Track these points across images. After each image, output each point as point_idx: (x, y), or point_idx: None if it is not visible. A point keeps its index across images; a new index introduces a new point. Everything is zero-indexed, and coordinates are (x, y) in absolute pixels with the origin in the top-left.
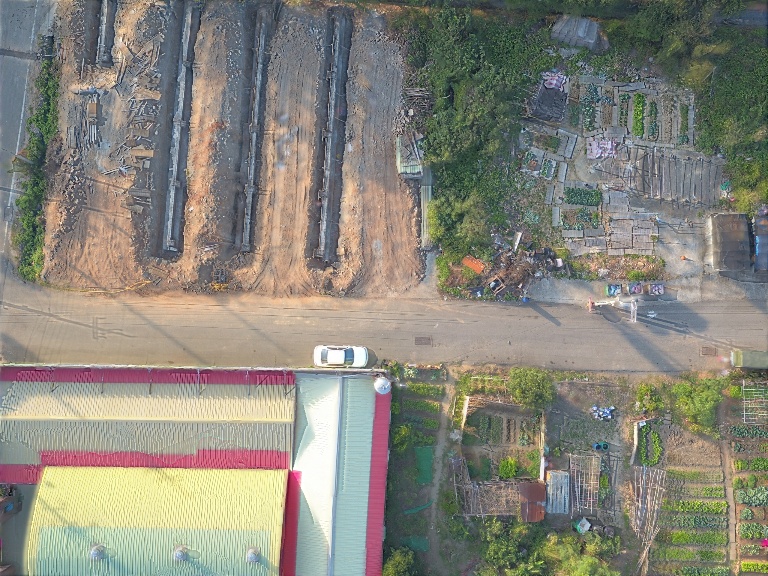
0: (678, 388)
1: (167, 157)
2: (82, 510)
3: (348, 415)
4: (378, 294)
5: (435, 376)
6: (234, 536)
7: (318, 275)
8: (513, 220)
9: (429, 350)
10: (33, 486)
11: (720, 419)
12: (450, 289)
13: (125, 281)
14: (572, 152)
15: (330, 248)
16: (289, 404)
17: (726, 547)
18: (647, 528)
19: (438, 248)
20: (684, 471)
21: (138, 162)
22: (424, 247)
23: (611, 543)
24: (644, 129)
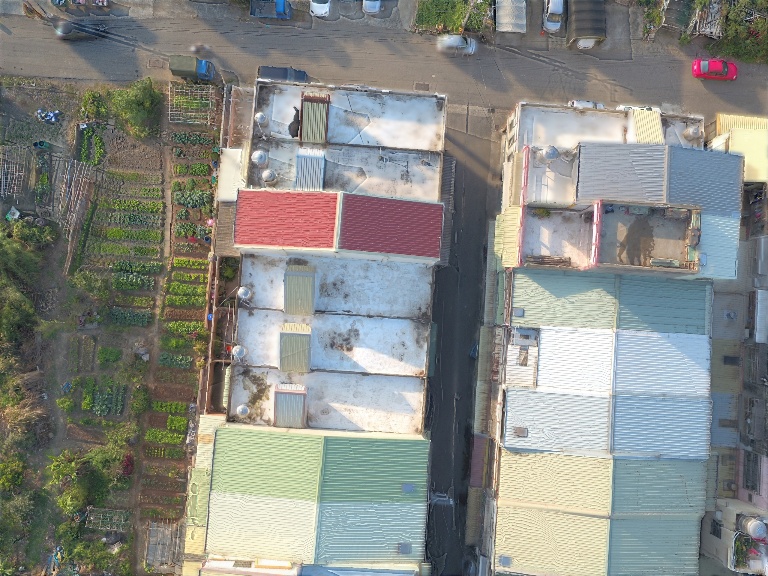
0: (115, 92)
1: None
2: None
3: None
4: None
5: None
6: None
7: None
8: None
9: None
10: None
11: (163, 126)
12: None
13: None
14: None
15: None
16: None
17: (161, 244)
18: (69, 215)
19: None
20: (123, 172)
21: None
22: None
23: (35, 229)
24: None
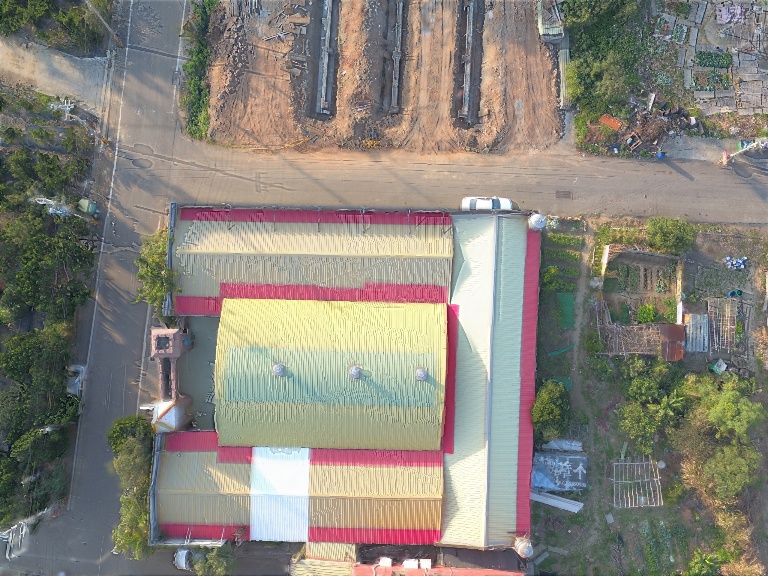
0: None
1: (318, 28)
2: (262, 334)
3: (503, 251)
4: (520, 151)
5: (575, 227)
6: (400, 360)
7: (463, 133)
8: (647, 82)
9: (569, 203)
10: (203, 326)
11: None
12: (589, 146)
13: (285, 139)
14: (702, 18)
15: (472, 111)
16: (447, 241)
17: None
18: None
19: (576, 108)
20: None
21: (296, 28)
22: (564, 106)
23: (747, 382)
24: None
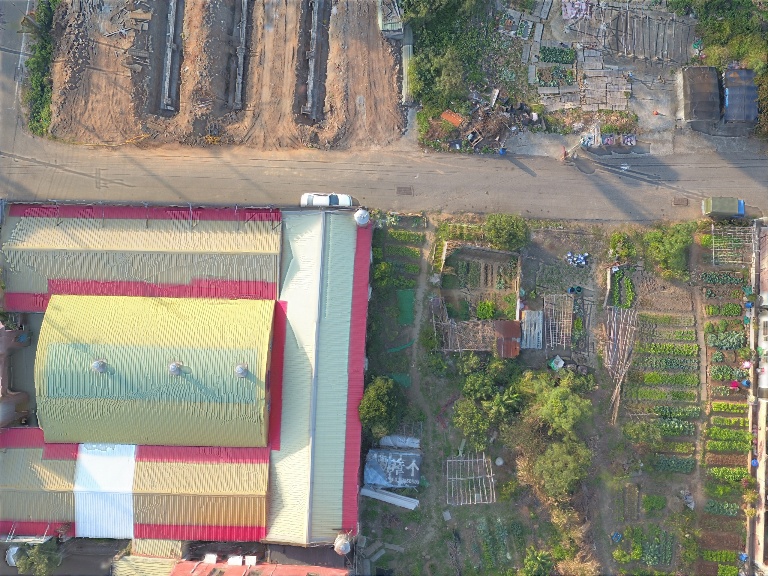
0: (650, 234)
1: (165, 24)
2: (84, 330)
3: (330, 248)
4: (362, 147)
5: (416, 224)
6: (224, 357)
7: (305, 129)
8: (491, 78)
9: (410, 199)
10: (41, 323)
11: (692, 266)
12: (430, 142)
13: (125, 135)
14: (548, 13)
15: (317, 107)
16: (275, 238)
17: (697, 388)
18: (618, 364)
19: (419, 104)
20: (656, 315)
21: (137, 24)
22: (405, 102)
23: (584, 379)
24: None
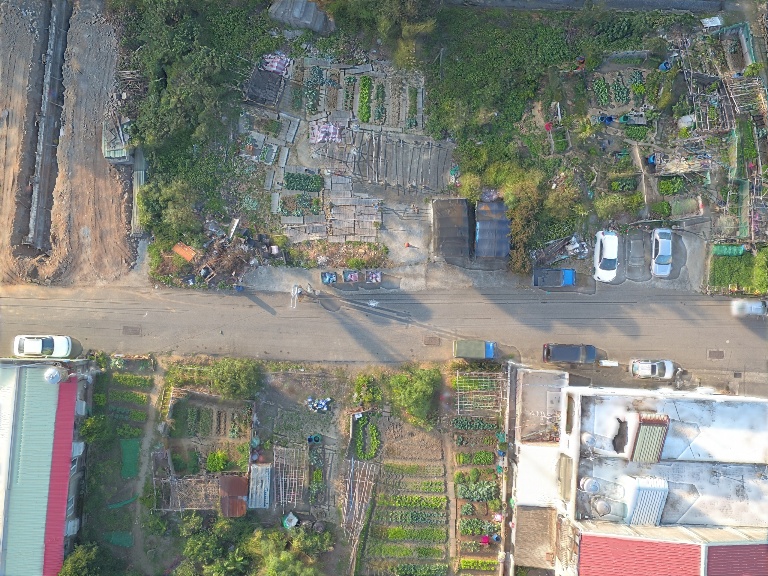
0: (394, 379)
1: None
2: None
3: (26, 406)
4: (86, 282)
5: (143, 366)
6: None
7: (24, 263)
8: (230, 206)
9: (137, 340)
10: None
11: (442, 411)
12: (160, 277)
13: None
14: (294, 136)
15: (44, 235)
16: None
17: (446, 543)
18: (354, 523)
19: (151, 235)
20: (403, 465)
21: None
22: (134, 234)
23: (317, 539)
24: (370, 113)
